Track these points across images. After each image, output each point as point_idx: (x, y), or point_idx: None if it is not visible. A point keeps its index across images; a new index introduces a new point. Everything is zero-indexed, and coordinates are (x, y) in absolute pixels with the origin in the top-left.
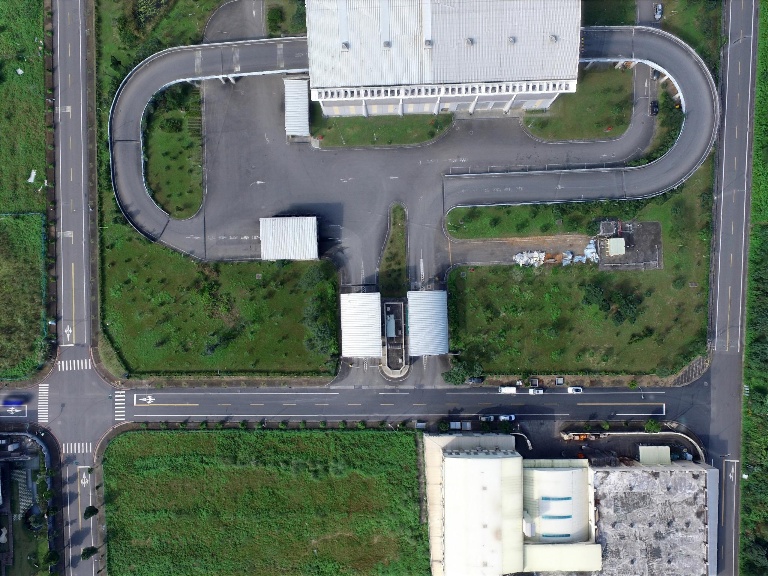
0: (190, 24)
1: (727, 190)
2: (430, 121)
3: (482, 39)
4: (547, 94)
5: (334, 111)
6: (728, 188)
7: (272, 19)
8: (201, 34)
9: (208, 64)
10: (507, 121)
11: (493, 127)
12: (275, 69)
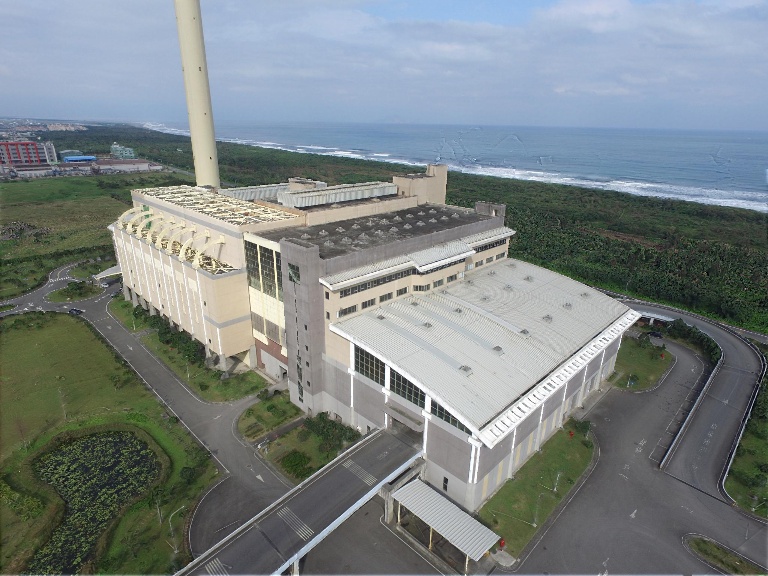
0: (155, 554)
1: (764, 342)
2: (567, 436)
3: (551, 315)
4: (615, 345)
5: (481, 492)
6: (762, 341)
7: (294, 465)
8: (185, 554)
9: (246, 567)
10: (610, 395)
11: (611, 405)
12: (368, 490)
